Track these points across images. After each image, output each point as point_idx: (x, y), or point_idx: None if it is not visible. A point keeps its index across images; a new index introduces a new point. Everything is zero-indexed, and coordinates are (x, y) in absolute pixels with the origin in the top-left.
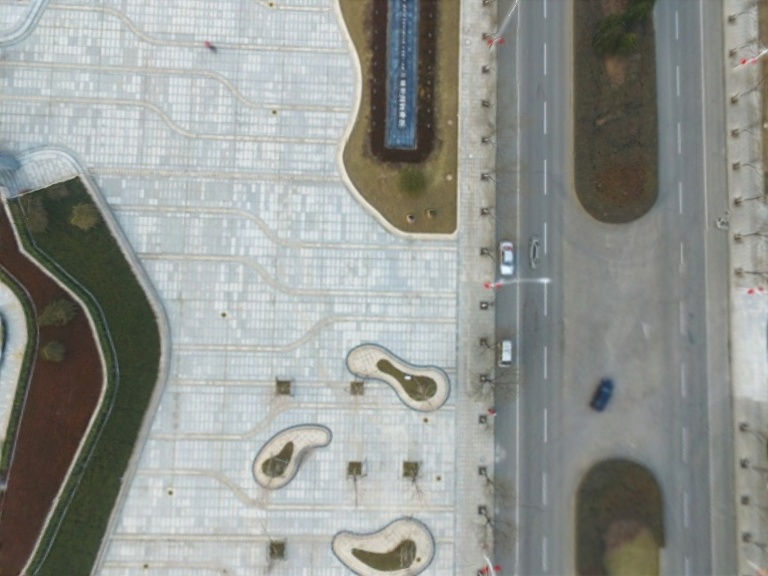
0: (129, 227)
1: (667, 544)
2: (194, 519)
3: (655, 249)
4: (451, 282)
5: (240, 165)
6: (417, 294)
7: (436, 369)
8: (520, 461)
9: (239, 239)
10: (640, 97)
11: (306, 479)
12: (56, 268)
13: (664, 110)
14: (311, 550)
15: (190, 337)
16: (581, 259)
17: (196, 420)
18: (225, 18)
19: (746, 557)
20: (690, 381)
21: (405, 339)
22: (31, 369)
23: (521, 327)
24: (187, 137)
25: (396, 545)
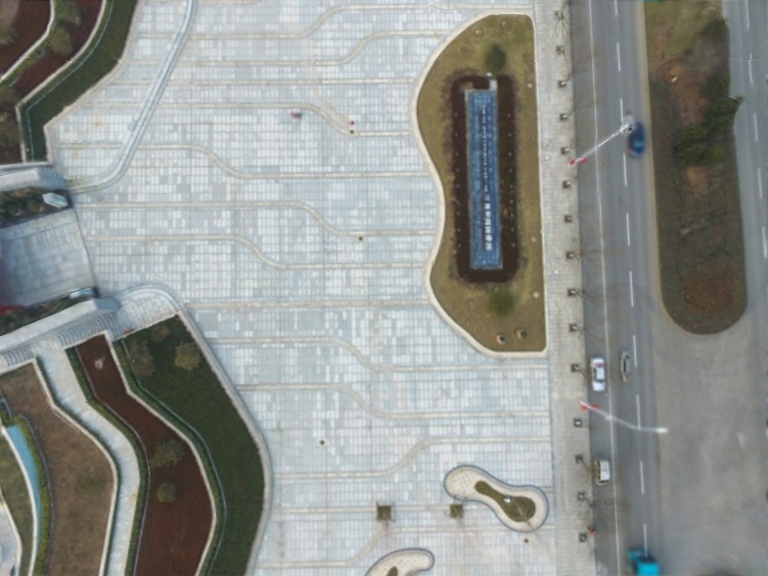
0: (227, 360)
1: None
2: None
3: (746, 357)
4: (543, 400)
5: (330, 293)
6: (510, 413)
7: (533, 488)
8: None
9: (333, 366)
10: (724, 204)
11: None
12: (162, 407)
13: (748, 215)
14: None
15: (291, 466)
16: (672, 370)
17: (301, 548)
18: (308, 148)
19: None
20: None
21: (501, 459)
22: (144, 509)
23: (615, 442)
24: (278, 268)
25: None
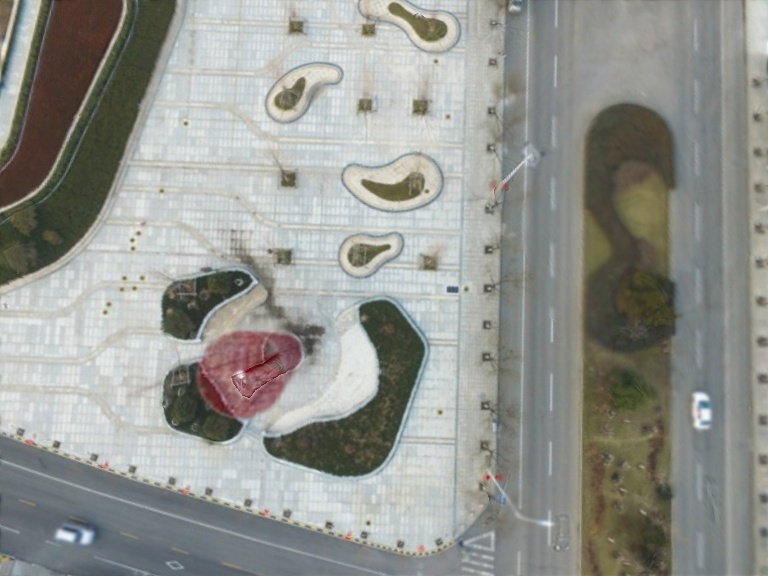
0: None
1: (677, 185)
2: (208, 149)
3: None
4: None
5: None
6: None
7: (447, 14)
8: (529, 104)
9: None
10: None
11: (317, 114)
12: None
13: None
14: (321, 181)
15: None
16: None
17: (211, 56)
18: None
19: (758, 203)
20: (703, 35)
21: None
22: None
23: None
24: None
25: (405, 176)
